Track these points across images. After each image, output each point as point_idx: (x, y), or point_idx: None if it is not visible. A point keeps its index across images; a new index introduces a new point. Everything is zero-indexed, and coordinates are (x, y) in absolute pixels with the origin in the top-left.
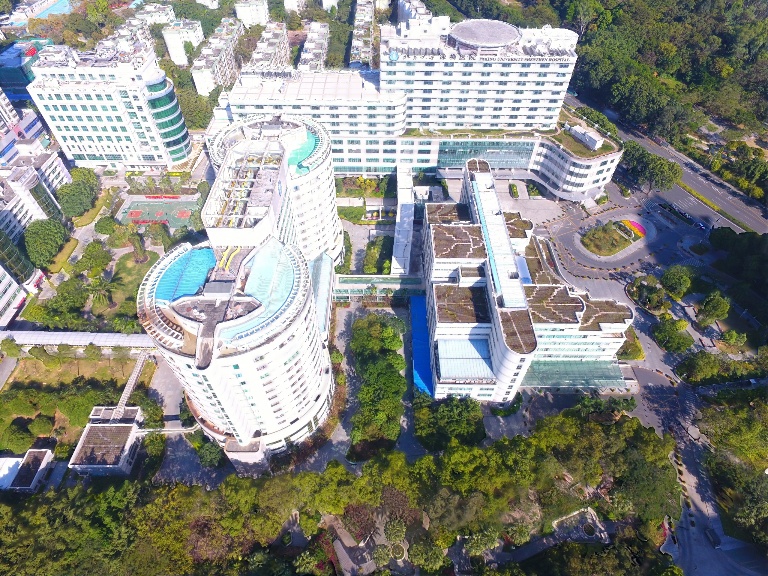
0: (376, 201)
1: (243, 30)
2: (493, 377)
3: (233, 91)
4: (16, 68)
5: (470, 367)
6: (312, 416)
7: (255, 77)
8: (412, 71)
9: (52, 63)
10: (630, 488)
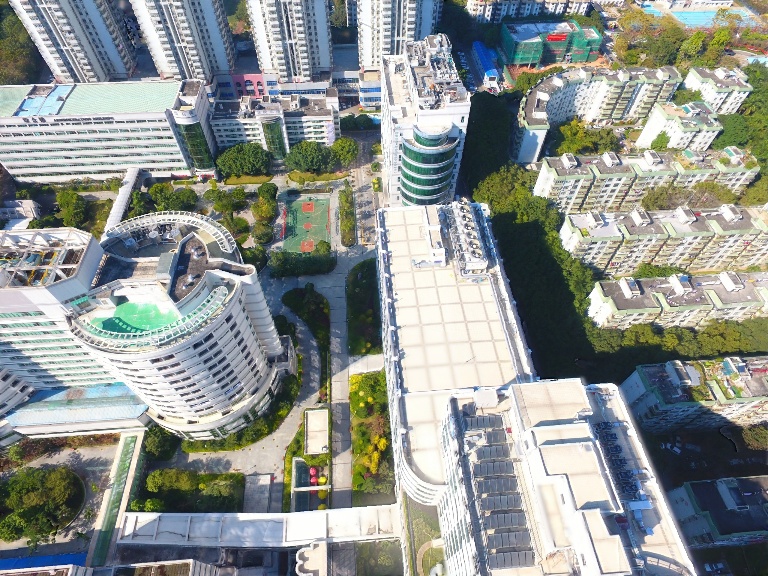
0: (344, 477)
1: (744, 181)
2: None
3: (409, 209)
4: (514, 41)
5: None
6: None
7: (431, 222)
8: None
9: None
10: None
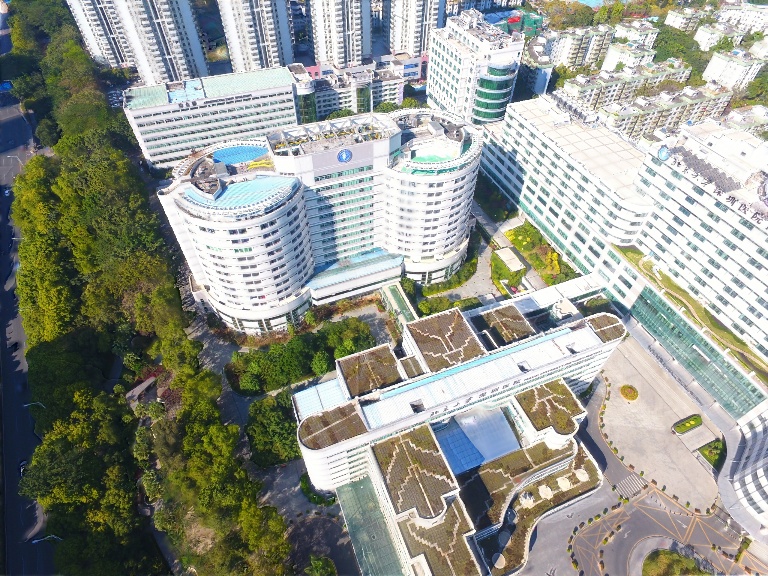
0: (539, 283)
1: (684, 78)
2: None
3: (524, 103)
4: None
5: None
6: (237, 316)
7: (550, 101)
8: (675, 185)
9: (460, 21)
10: None
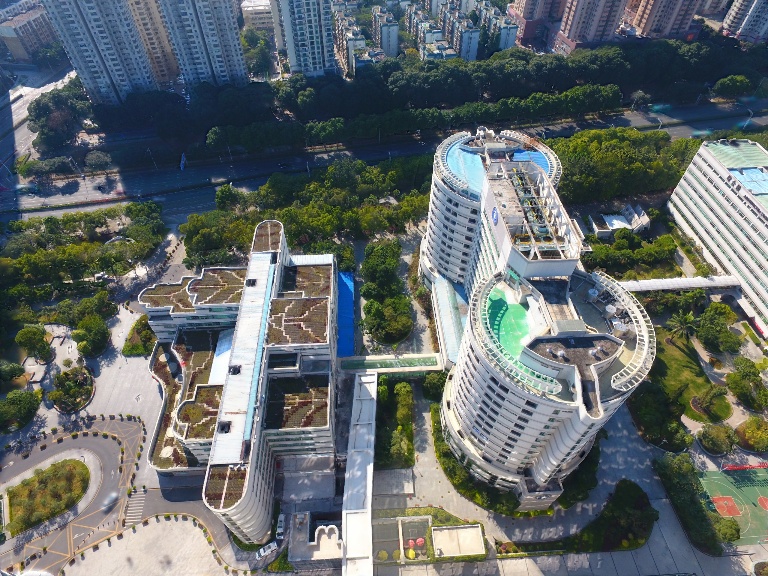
0: None
1: None
2: (291, 256)
3: None
4: None
5: (308, 261)
6: None
7: None
8: None
9: None
10: (224, 213)
